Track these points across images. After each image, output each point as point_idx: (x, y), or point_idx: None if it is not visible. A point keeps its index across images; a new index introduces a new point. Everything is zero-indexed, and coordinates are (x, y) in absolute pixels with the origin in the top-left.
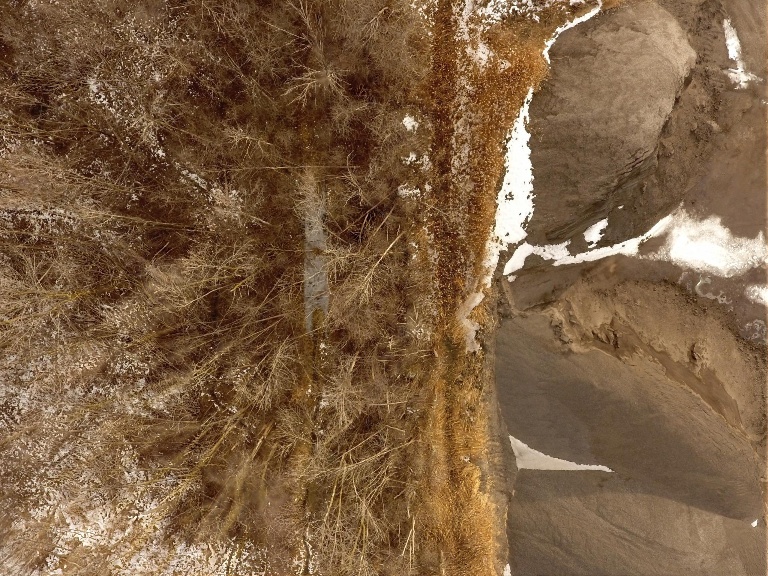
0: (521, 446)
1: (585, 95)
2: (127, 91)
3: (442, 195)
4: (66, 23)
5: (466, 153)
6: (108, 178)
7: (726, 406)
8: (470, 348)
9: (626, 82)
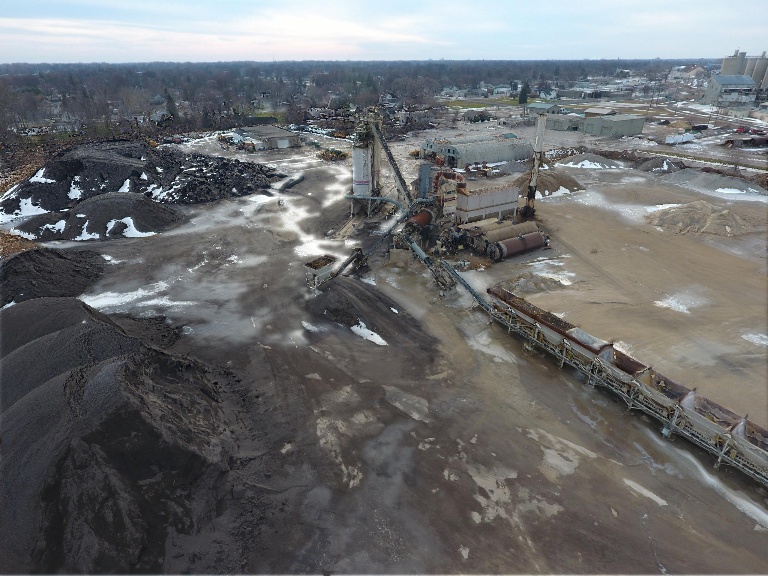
0: None
1: None
2: None
3: None
4: None
5: None
6: None
7: None
8: None
9: None
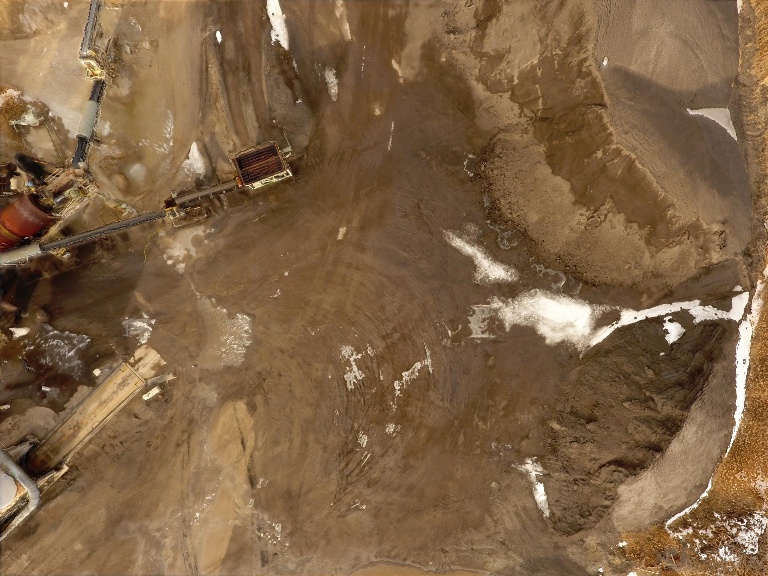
0: (730, 131)
1: None
2: None
3: None
4: None
5: None
6: None
7: (611, 173)
8: (767, 224)
9: None
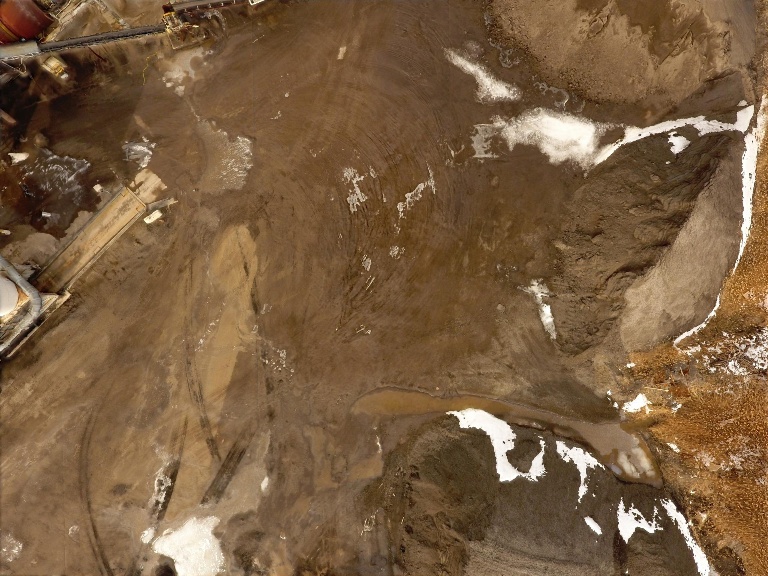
0: None
1: None
2: None
3: None
4: None
5: None
6: None
7: None
8: None
9: None
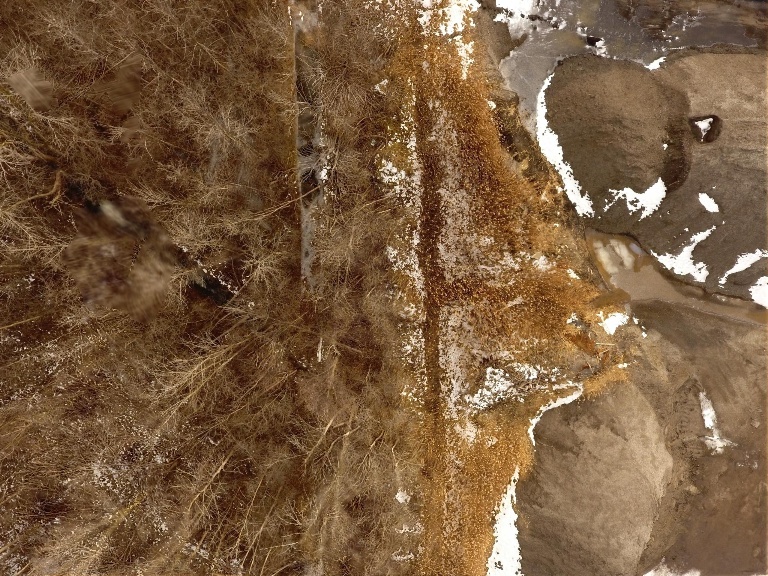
0: None
1: (568, 499)
2: (130, 473)
3: (435, 555)
4: (69, 413)
5: (457, 520)
6: (113, 552)
7: None
8: None
9: (606, 500)
